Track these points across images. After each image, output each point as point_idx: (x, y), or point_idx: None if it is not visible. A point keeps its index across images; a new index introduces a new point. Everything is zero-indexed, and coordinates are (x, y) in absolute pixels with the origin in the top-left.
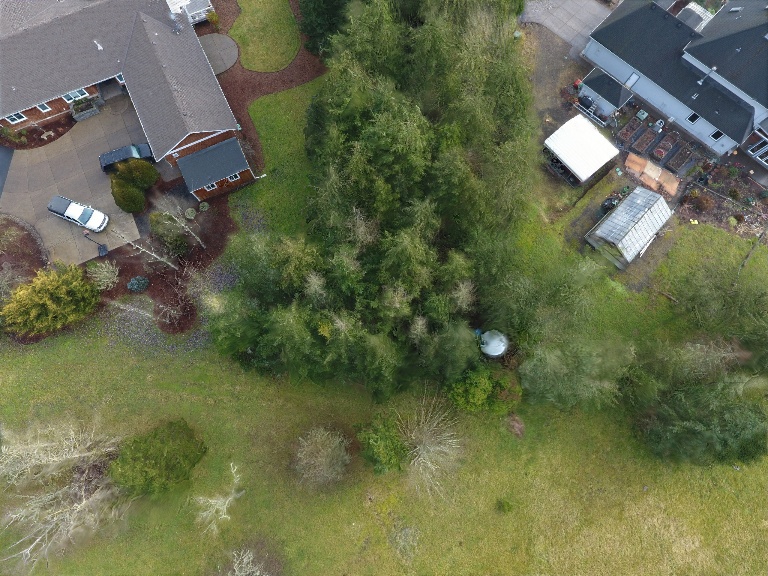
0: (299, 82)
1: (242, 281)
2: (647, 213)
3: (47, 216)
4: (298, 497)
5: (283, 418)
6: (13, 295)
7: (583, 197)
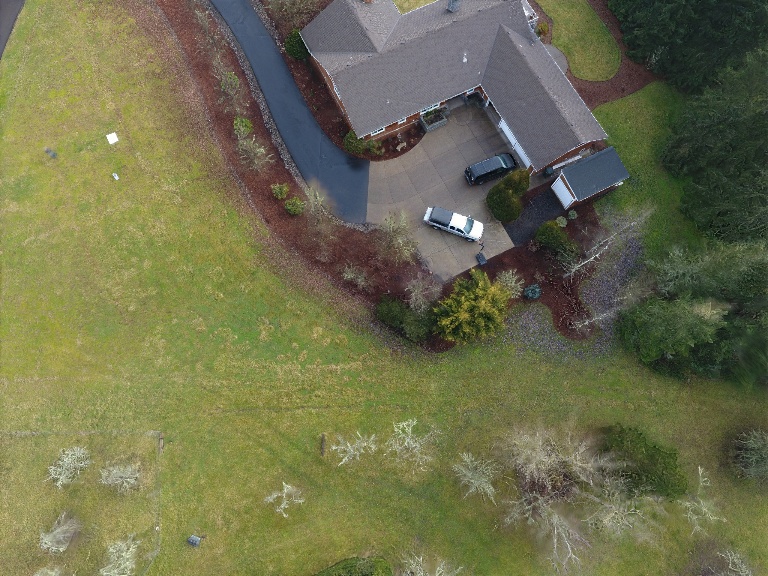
0: (630, 90)
1: (663, 288)
2: None
3: (417, 226)
4: (736, 498)
5: (703, 421)
6: (463, 305)
7: None
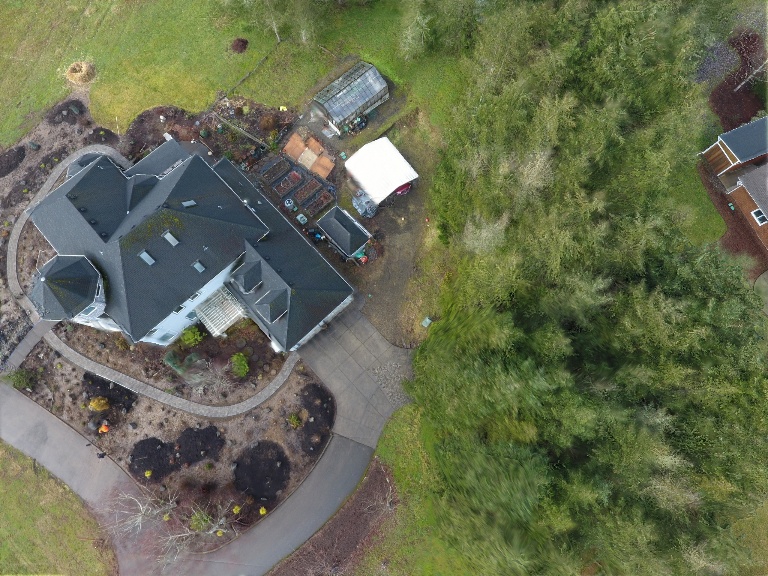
0: None
1: None
2: (341, 90)
3: None
4: None
5: None
6: None
7: (384, 132)
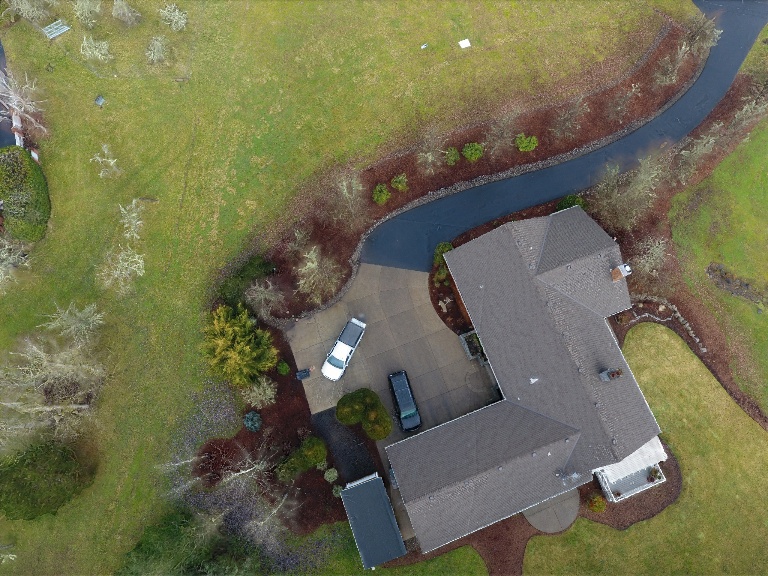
0: None
1: (212, 569)
2: None
3: (350, 313)
4: None
5: None
6: None
7: None
